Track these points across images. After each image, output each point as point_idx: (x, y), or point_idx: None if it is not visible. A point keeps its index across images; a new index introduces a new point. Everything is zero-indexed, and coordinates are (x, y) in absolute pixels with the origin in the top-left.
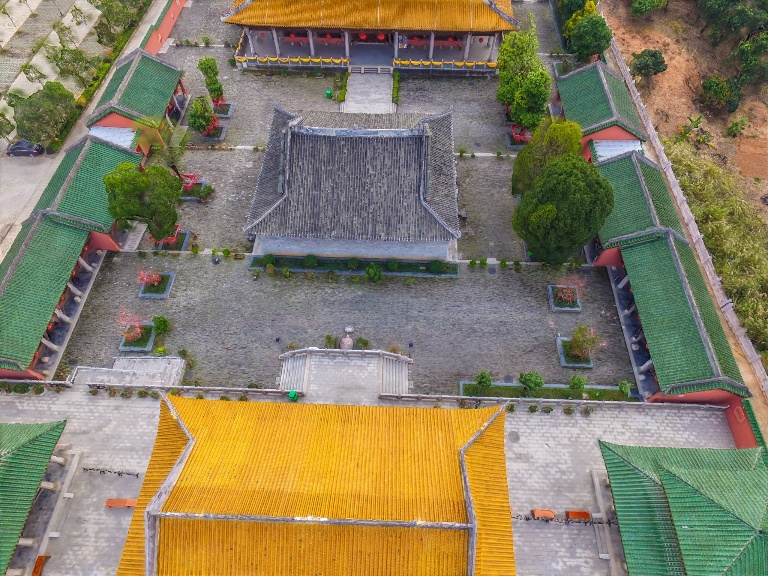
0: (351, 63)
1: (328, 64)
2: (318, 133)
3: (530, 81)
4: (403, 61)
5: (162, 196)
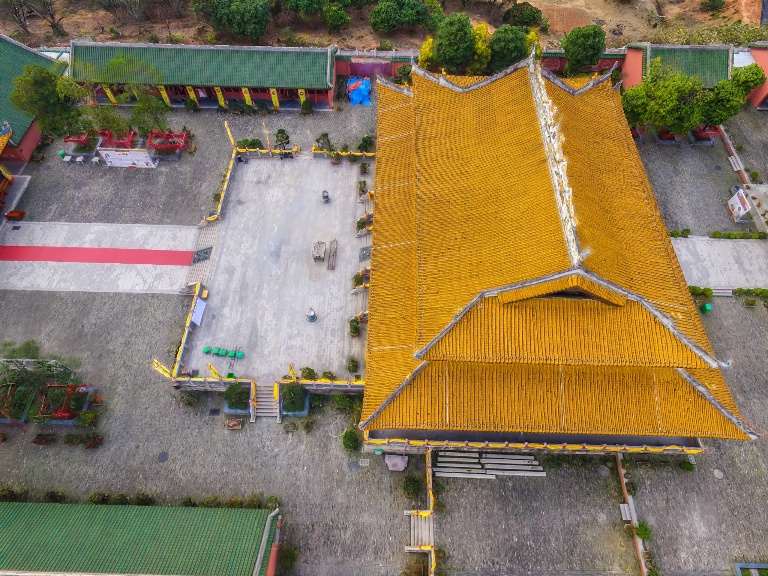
0: None
1: None
2: None
3: None
4: None
5: None
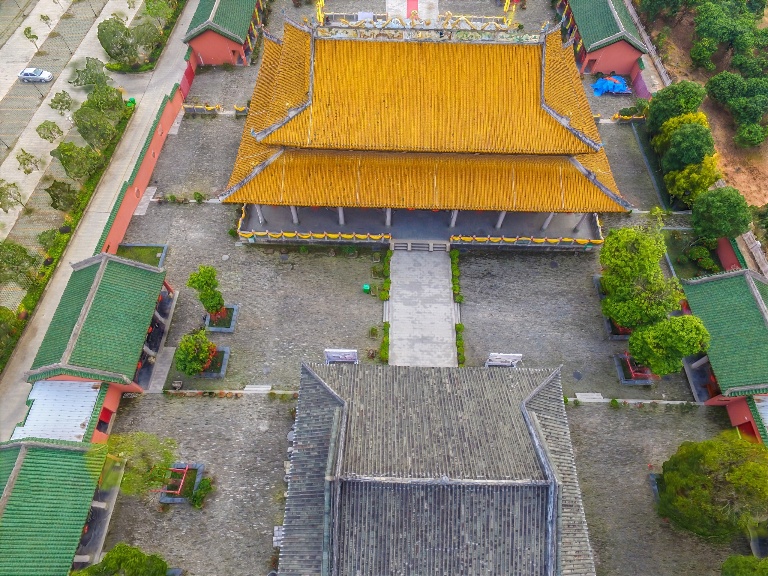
0: (393, 236)
1: (363, 239)
2: (383, 480)
3: (679, 337)
4: (464, 237)
5: None
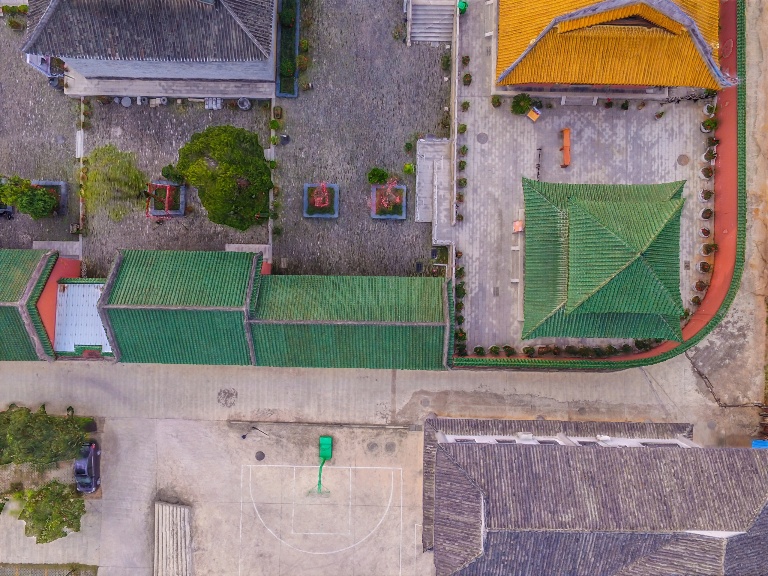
0: None
1: None
2: None
3: None
4: None
5: (238, 129)
